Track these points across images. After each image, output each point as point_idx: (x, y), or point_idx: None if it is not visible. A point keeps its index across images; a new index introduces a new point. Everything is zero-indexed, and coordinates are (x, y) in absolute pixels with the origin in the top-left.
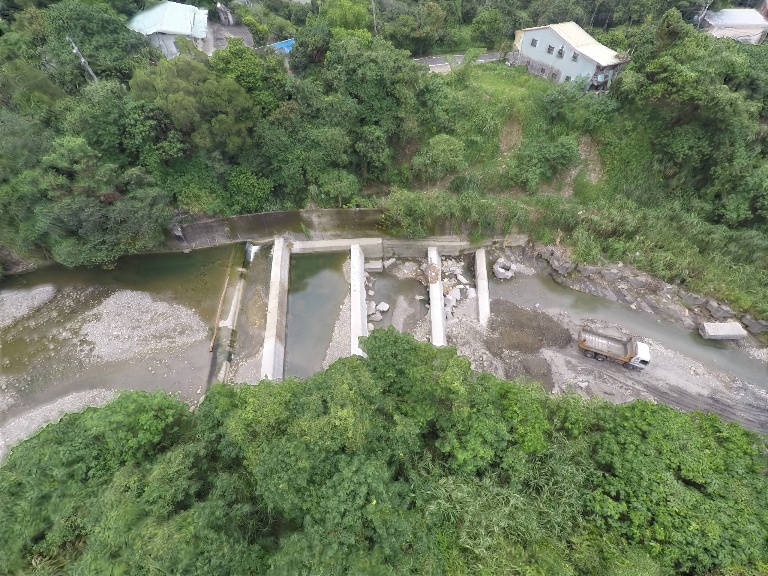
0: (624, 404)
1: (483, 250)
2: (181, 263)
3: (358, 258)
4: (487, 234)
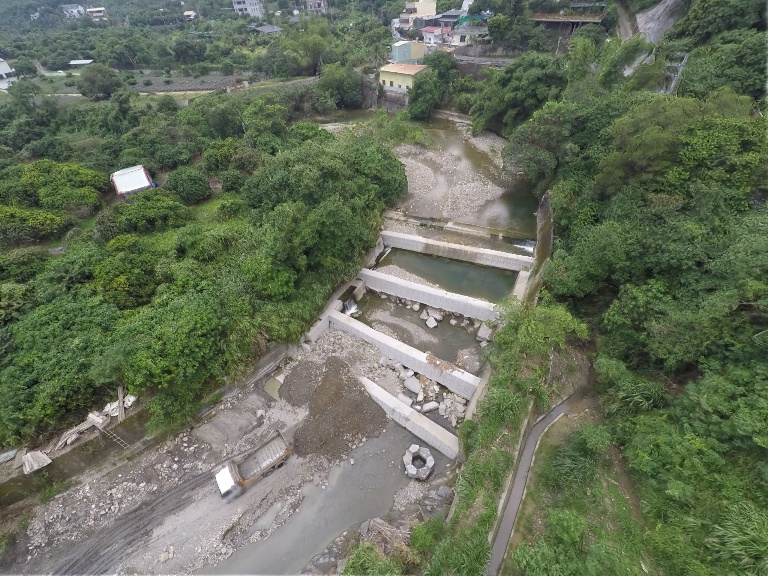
0: (214, 324)
1: (456, 448)
2: (525, 213)
3: (486, 307)
4: (469, 450)
